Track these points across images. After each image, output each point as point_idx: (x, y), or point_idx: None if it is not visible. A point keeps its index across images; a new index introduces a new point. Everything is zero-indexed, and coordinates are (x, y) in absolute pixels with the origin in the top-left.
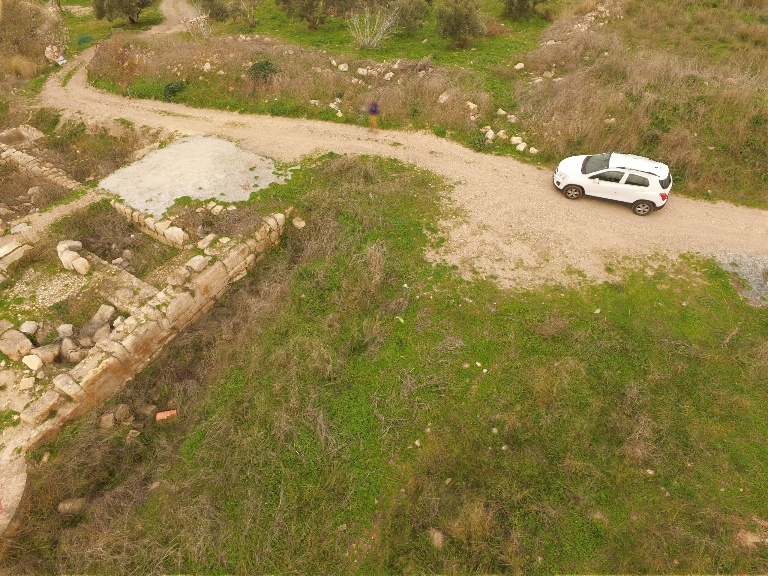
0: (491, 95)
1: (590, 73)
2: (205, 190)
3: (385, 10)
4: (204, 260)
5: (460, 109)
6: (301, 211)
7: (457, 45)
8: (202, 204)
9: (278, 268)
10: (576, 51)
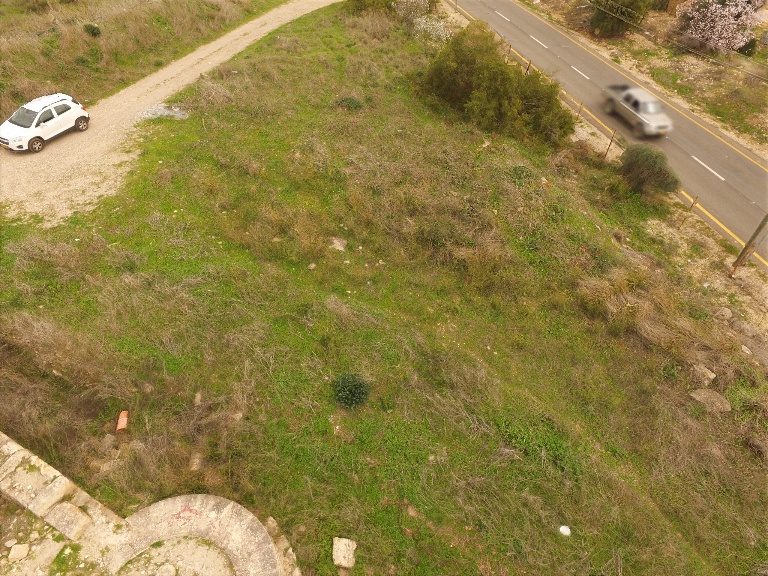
0: None
1: None
2: None
3: None
4: None
5: None
6: None
7: None
8: None
9: None
10: None
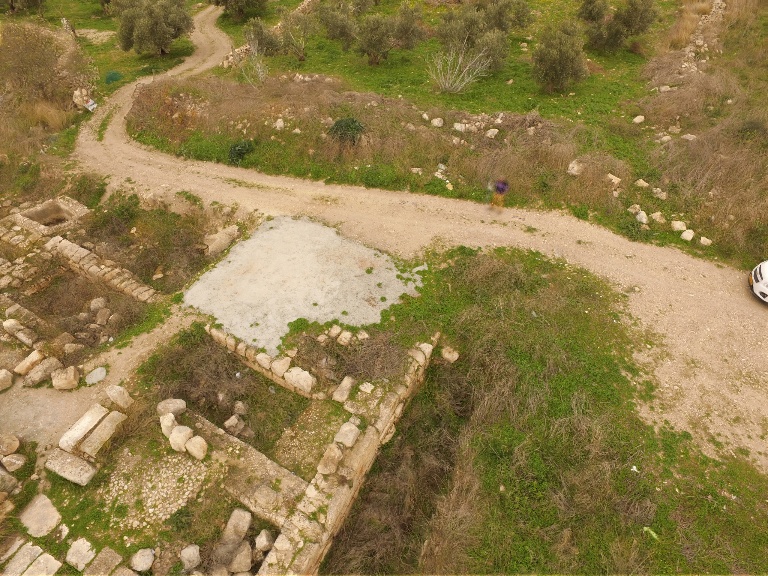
0: (619, 158)
1: (735, 133)
2: (321, 307)
3: (471, 49)
4: (357, 431)
5: (603, 185)
6: (452, 339)
7: (553, 89)
8: (323, 329)
9: (461, 445)
10: (698, 99)
